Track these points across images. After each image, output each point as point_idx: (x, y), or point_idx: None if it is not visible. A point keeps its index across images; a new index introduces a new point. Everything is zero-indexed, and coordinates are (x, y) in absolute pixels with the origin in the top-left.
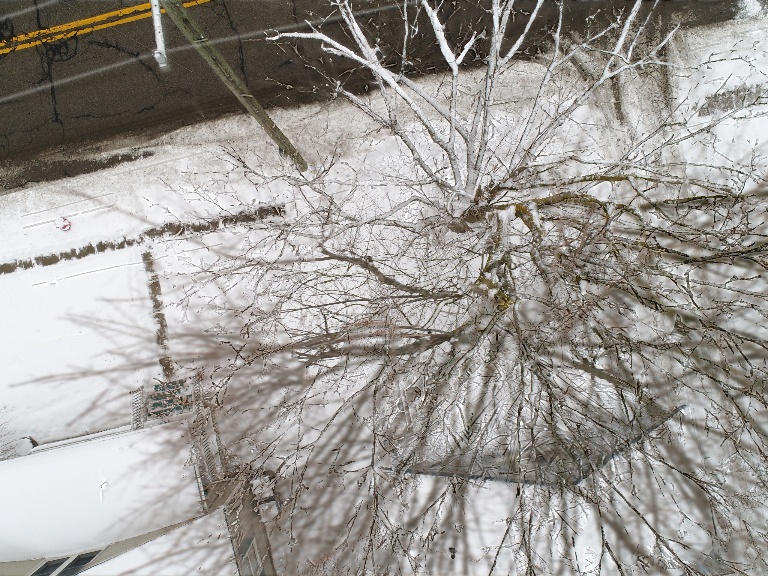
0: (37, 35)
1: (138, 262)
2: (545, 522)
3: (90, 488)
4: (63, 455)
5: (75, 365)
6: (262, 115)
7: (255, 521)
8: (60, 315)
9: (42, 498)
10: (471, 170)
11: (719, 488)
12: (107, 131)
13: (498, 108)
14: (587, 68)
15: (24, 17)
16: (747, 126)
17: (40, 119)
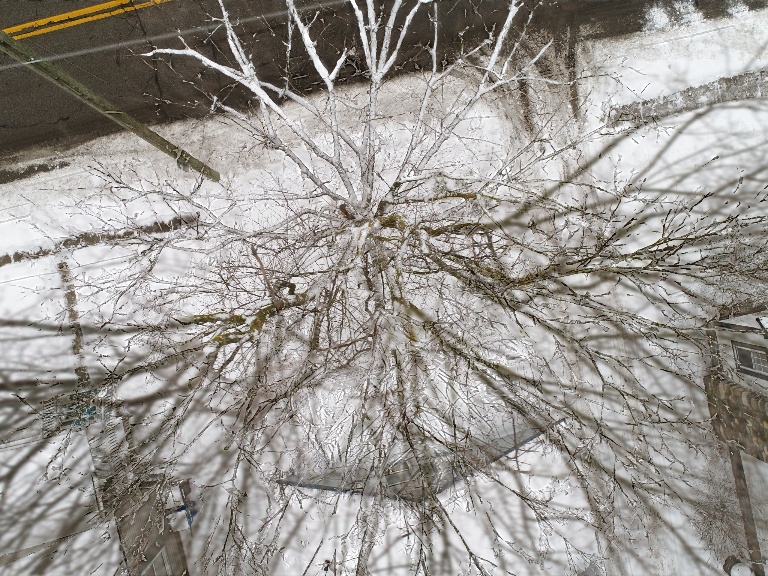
0: None
1: (54, 272)
2: (380, 538)
3: None
4: None
5: None
6: (140, 130)
7: (166, 530)
8: None
9: None
10: None
11: (544, 506)
12: (23, 141)
13: (407, 119)
14: (496, 79)
15: None
16: (653, 137)
17: None
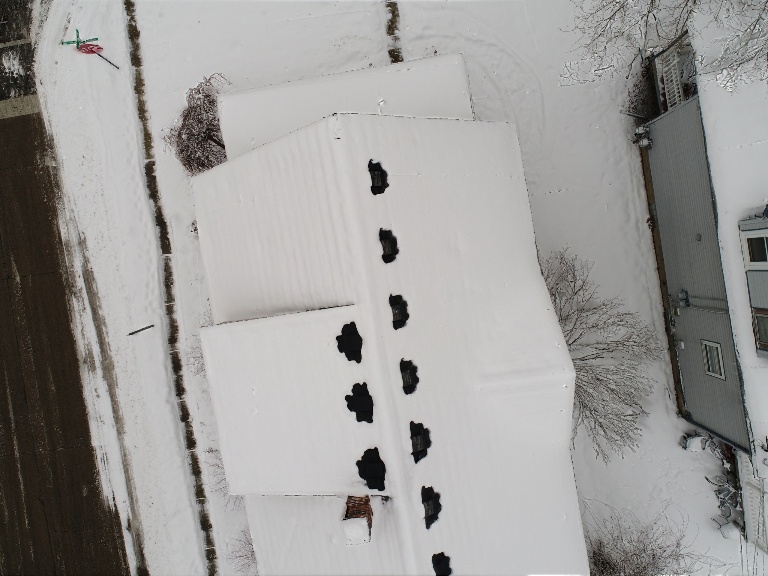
0: None
1: None
2: None
3: (367, 105)
4: (334, 77)
5: (301, 49)
6: None
7: None
8: None
9: (313, 115)
10: None
11: None
12: None
13: None
14: None
15: None
16: None
17: None
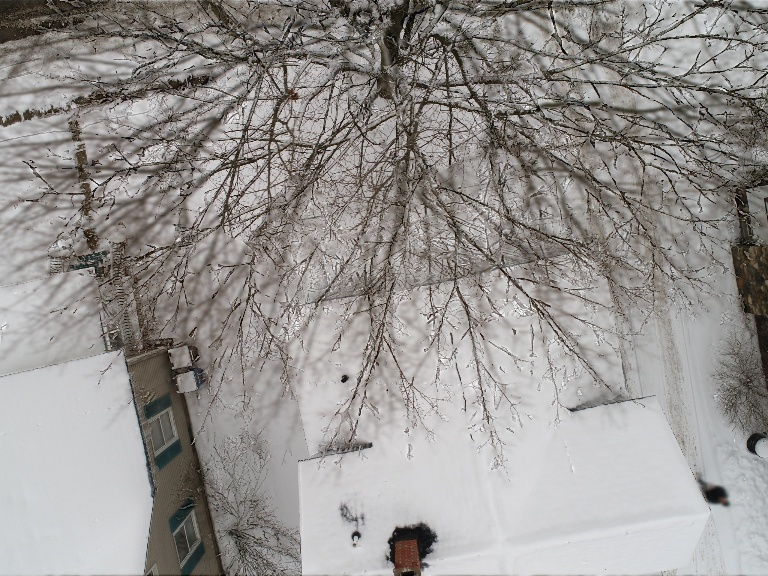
0: None
1: None
2: (409, 292)
3: None
4: None
5: None
6: None
7: (173, 392)
8: None
9: None
10: None
11: (585, 248)
12: None
13: None
14: None
15: None
16: None
17: None
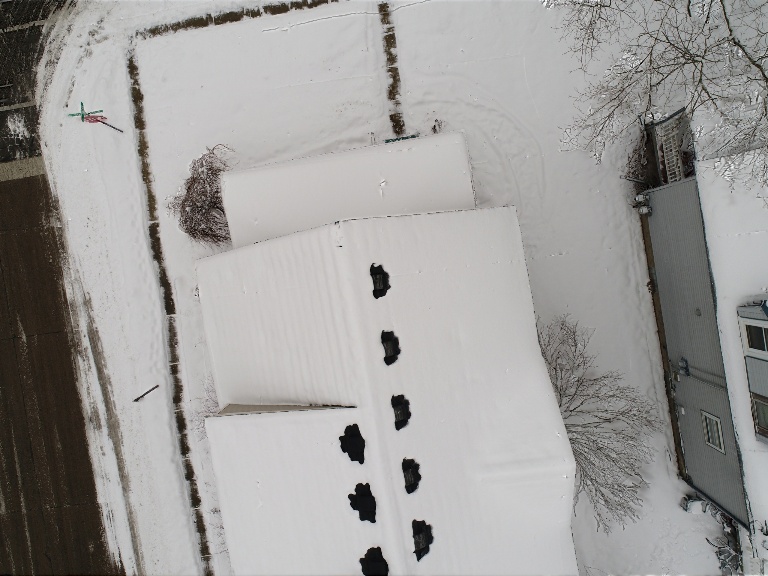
0: None
1: (374, 13)
2: None
3: (369, 186)
4: (336, 156)
5: (303, 115)
6: None
7: None
8: (291, 62)
9: (316, 195)
10: None
11: None
12: None
13: None
14: None
15: None
16: None
17: None
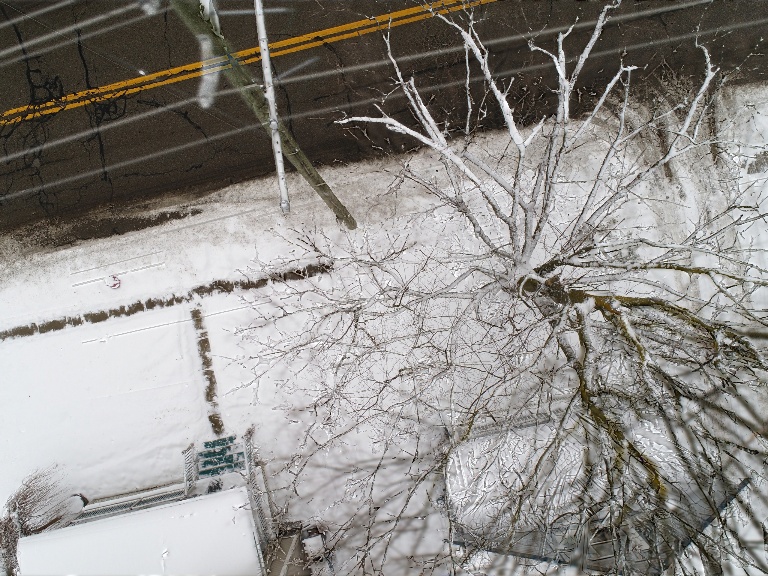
0: (86, 94)
1: (187, 319)
2: None
3: (152, 557)
4: (123, 523)
5: (125, 422)
6: (330, 196)
7: None
8: (110, 373)
9: (103, 567)
10: (529, 239)
11: None
12: (155, 189)
13: None
14: (635, 126)
15: (73, 77)
16: None
17: (89, 177)
